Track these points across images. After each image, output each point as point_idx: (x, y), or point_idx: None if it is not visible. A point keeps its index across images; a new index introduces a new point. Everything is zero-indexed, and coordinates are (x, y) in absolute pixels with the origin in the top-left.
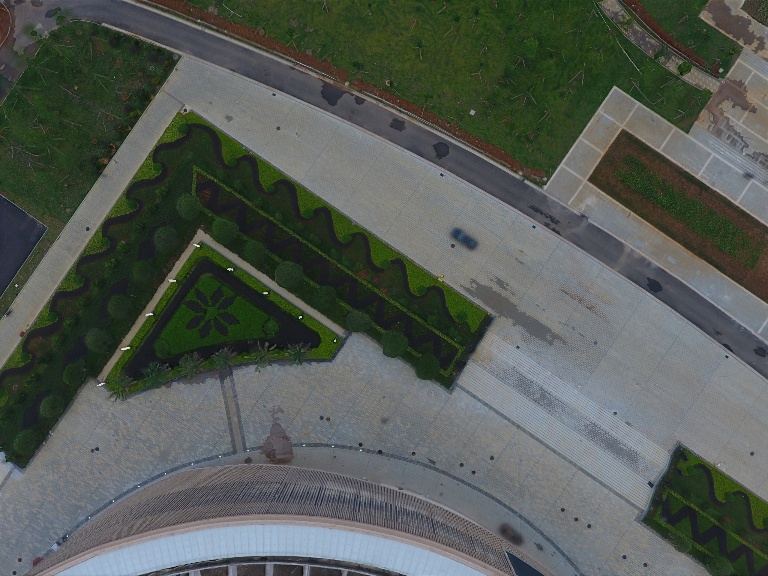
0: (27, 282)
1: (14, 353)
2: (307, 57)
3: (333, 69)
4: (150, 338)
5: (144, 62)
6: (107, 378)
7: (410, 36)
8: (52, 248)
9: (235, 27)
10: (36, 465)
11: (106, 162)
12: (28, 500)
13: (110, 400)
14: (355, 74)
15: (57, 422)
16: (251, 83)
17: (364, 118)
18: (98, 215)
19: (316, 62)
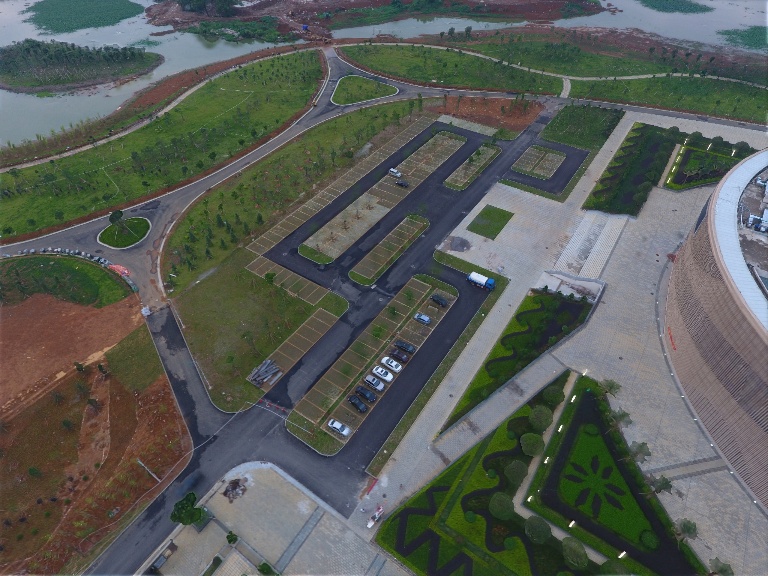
0: (589, 166)
1: (596, 186)
2: (684, 110)
3: (699, 112)
4: (680, 170)
5: None
6: (665, 184)
7: (727, 104)
8: None
9: None
10: (642, 216)
11: (610, 134)
12: (646, 230)
13: (670, 193)
14: (710, 113)
15: None
16: (663, 116)
17: (724, 123)
18: None
19: (689, 111)
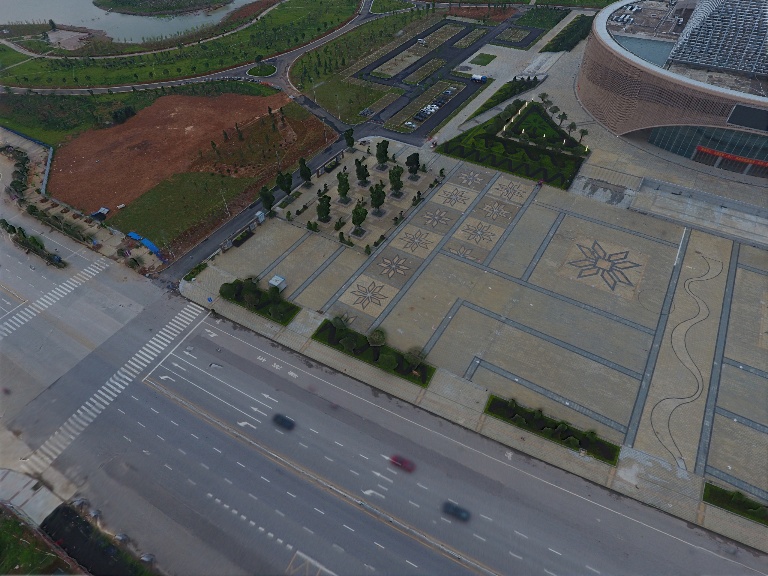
0: (545, 35)
1: None
2: None
3: None
4: None
5: (561, 11)
6: None
7: None
8: (550, 31)
9: (586, 6)
10: (573, 51)
11: (560, 21)
12: None
13: None
14: None
15: (576, 45)
16: None
17: None
18: None
19: None
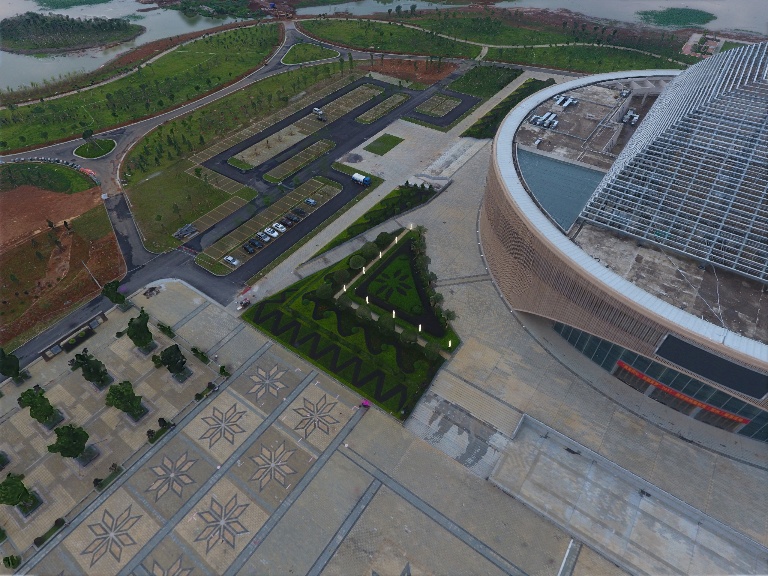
0: (478, 108)
1: None
2: (574, 70)
3: (586, 72)
4: None
5: None
6: None
7: None
8: (486, 102)
9: None
10: None
11: (504, 86)
12: None
13: None
14: (595, 72)
15: None
16: None
17: None
18: (504, 96)
19: (578, 71)
